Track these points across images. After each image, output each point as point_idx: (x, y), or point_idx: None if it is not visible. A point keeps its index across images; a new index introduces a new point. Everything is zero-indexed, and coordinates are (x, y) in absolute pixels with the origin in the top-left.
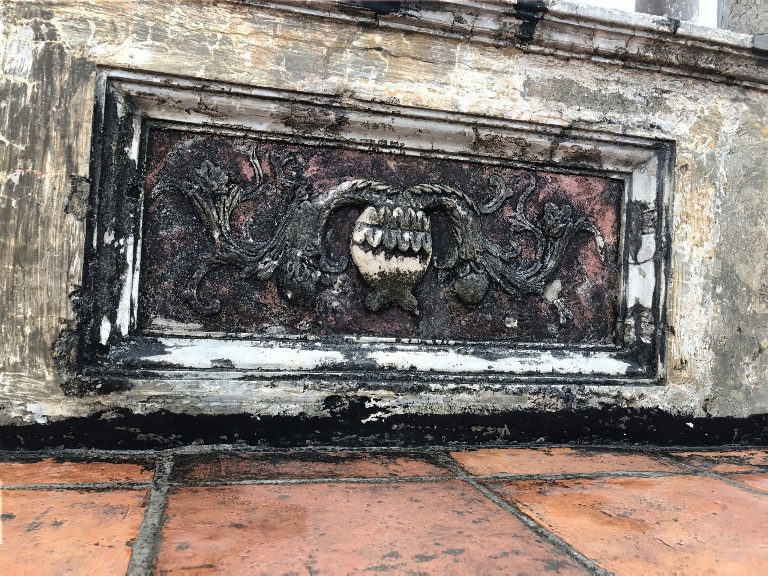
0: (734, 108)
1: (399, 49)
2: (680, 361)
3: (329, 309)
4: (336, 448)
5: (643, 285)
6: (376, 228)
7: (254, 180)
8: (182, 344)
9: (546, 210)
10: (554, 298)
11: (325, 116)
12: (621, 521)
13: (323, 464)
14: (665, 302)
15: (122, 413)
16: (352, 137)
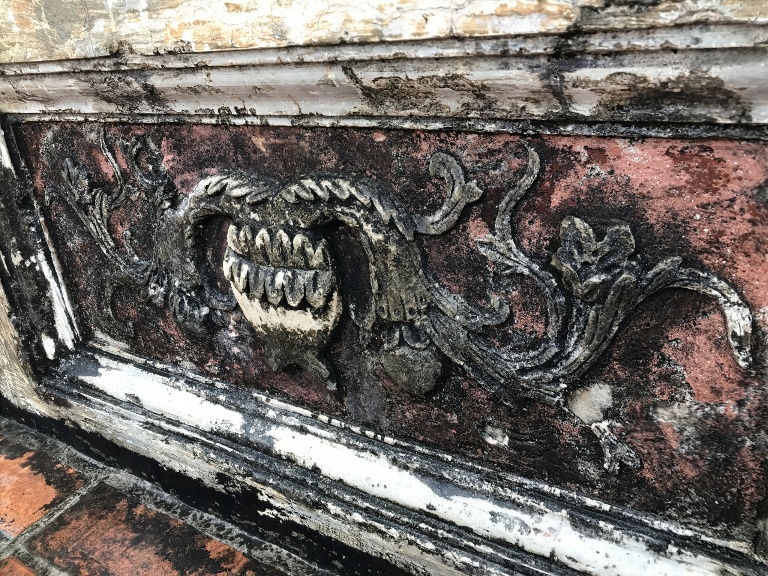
0: None
1: None
2: None
3: (231, 355)
4: (235, 529)
5: None
6: (243, 260)
7: (116, 179)
8: (112, 366)
9: (563, 235)
10: (593, 417)
11: (128, 86)
12: None
13: (162, 571)
14: None
15: (75, 425)
16: (183, 108)
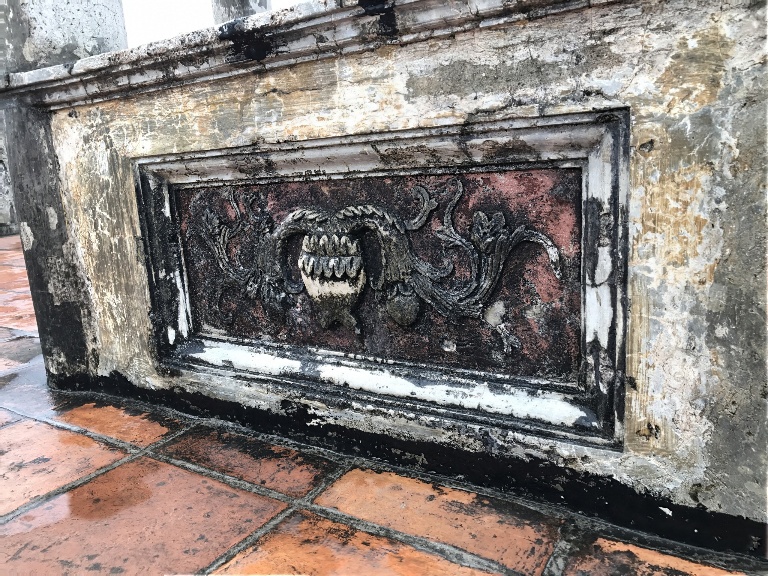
0: (755, 19)
1: (289, 85)
2: (647, 425)
3: (296, 324)
4: (290, 441)
5: (599, 316)
6: (311, 255)
7: (236, 219)
8: (213, 345)
9: (475, 221)
10: (497, 322)
11: (257, 161)
12: None
13: (244, 458)
14: (624, 343)
15: (182, 390)
16: (285, 173)
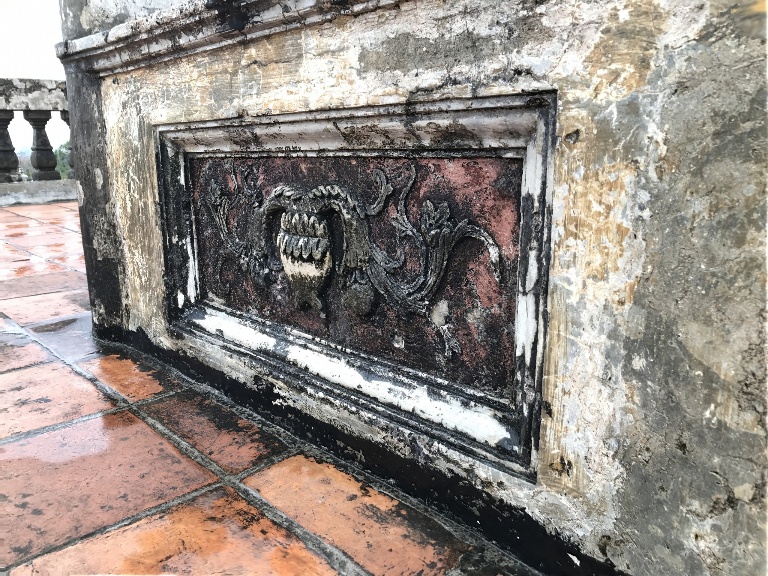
0: None
1: (266, 56)
2: (560, 459)
3: (277, 301)
4: (258, 417)
5: (526, 328)
6: (286, 233)
7: None
8: (213, 313)
9: (423, 210)
10: (441, 323)
11: (245, 134)
12: (148, 569)
13: (209, 426)
14: (543, 362)
15: (184, 353)
16: (270, 147)
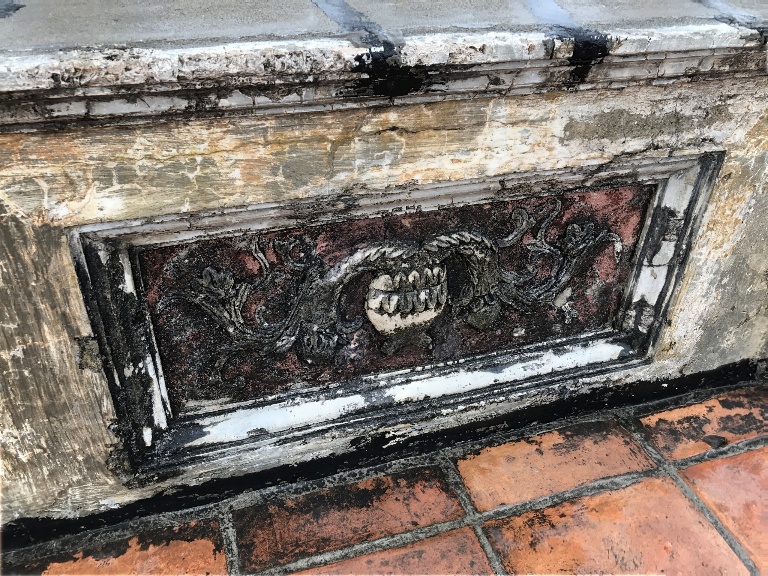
0: None
1: (418, 123)
2: (670, 344)
3: (347, 360)
4: (362, 470)
5: (652, 285)
6: (391, 294)
7: (260, 271)
8: (217, 420)
9: (568, 232)
10: (563, 303)
11: (333, 207)
12: None
13: (357, 514)
14: (669, 300)
15: (180, 488)
16: (363, 212)
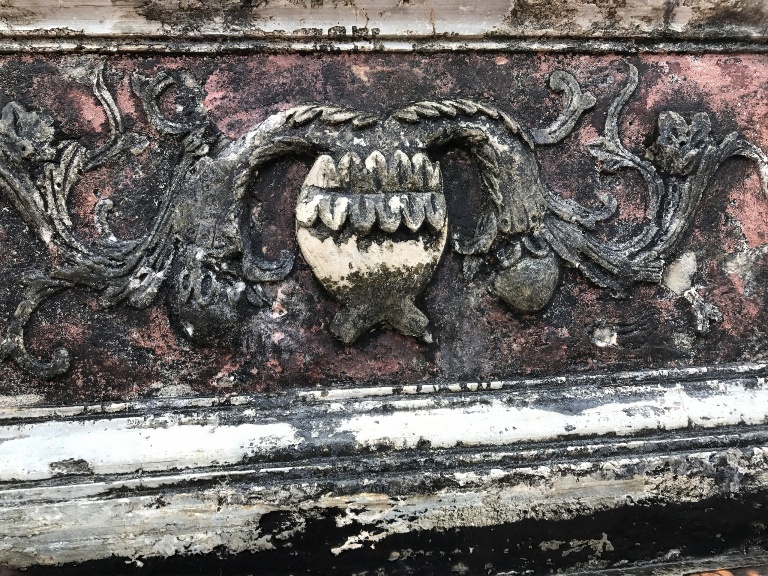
0: None
1: None
2: None
3: (267, 346)
4: None
5: None
6: (337, 194)
7: (106, 129)
8: (3, 436)
9: (661, 126)
10: (684, 286)
11: None
12: None
13: None
14: None
15: None
16: (277, 27)
